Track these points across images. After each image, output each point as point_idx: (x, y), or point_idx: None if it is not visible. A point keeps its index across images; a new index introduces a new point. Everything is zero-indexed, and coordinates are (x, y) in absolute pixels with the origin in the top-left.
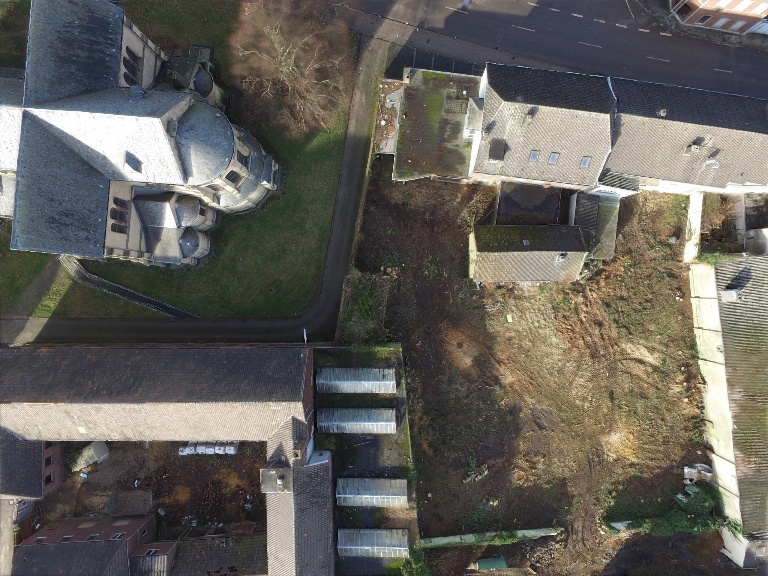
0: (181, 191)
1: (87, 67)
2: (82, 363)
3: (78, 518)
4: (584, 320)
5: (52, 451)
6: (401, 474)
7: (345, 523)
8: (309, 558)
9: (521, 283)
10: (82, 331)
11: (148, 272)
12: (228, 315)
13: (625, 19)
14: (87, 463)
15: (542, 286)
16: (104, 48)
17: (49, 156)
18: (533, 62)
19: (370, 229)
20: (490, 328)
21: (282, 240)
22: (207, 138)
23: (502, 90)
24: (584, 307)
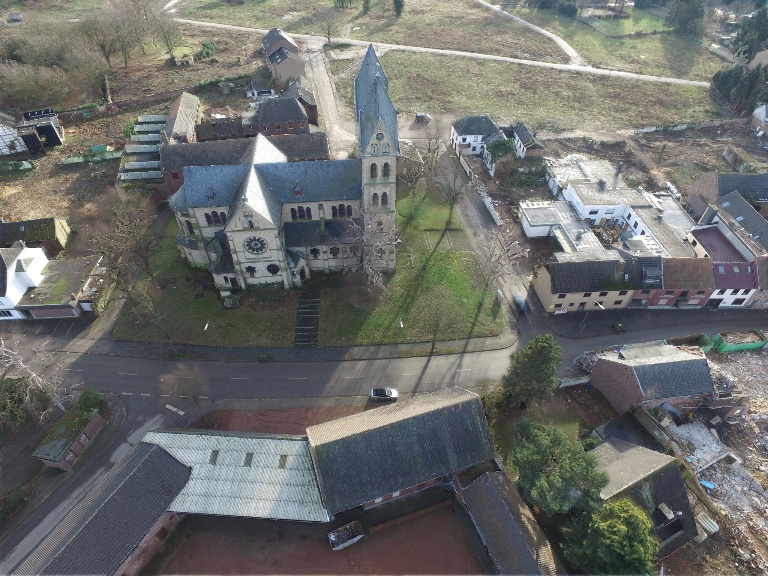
0: None
1: None
2: None
3: None
4: None
5: None
6: (129, 154)
7: None
8: None
9: None
10: None
11: None
12: None
13: None
14: None
15: None
16: None
17: None
18: None
19: None
20: None
21: None
22: None
23: None
24: None
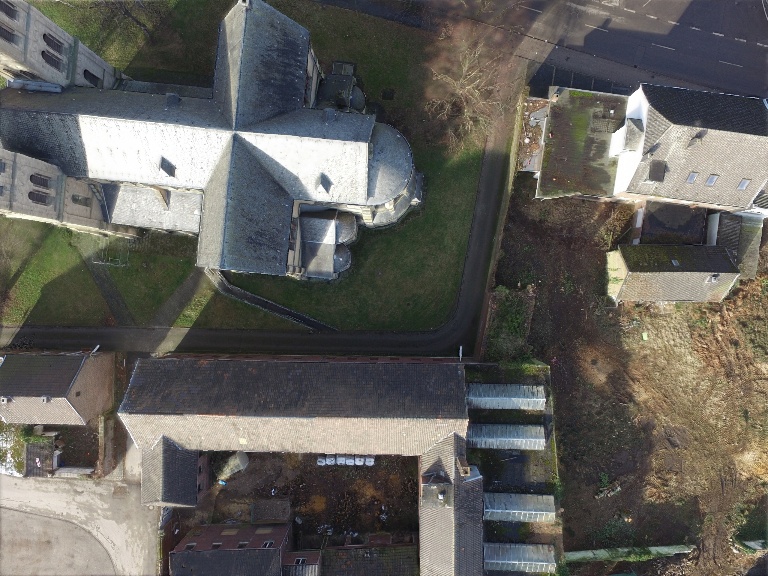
0: (345, 208)
1: (281, 89)
2: (244, 376)
3: (217, 525)
4: (720, 339)
5: (202, 460)
6: (547, 490)
7: (489, 537)
8: (465, 572)
9: (657, 301)
10: (222, 341)
11: (288, 285)
12: (366, 328)
13: (767, 38)
14: (232, 472)
15: (678, 305)
16: (294, 70)
17: (250, 177)
18: (672, 81)
19: (507, 245)
20: (625, 345)
21: (421, 255)
22: (393, 160)
23: (666, 112)
24: (720, 326)
